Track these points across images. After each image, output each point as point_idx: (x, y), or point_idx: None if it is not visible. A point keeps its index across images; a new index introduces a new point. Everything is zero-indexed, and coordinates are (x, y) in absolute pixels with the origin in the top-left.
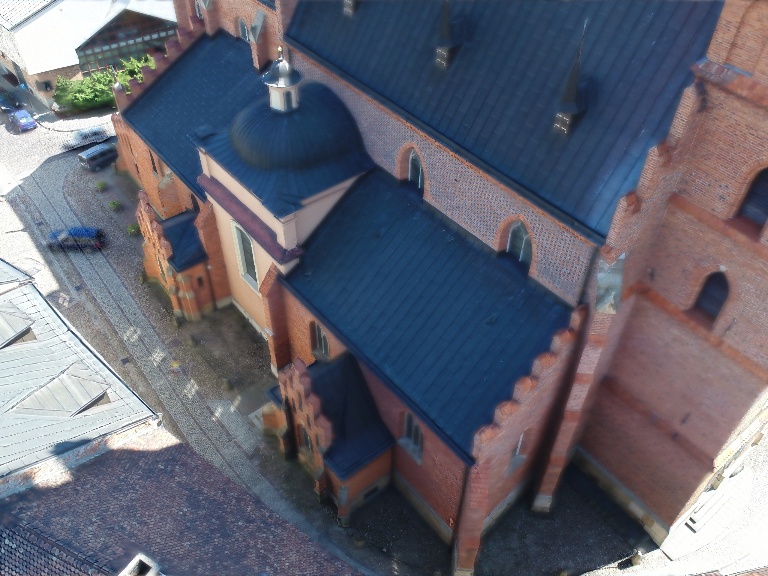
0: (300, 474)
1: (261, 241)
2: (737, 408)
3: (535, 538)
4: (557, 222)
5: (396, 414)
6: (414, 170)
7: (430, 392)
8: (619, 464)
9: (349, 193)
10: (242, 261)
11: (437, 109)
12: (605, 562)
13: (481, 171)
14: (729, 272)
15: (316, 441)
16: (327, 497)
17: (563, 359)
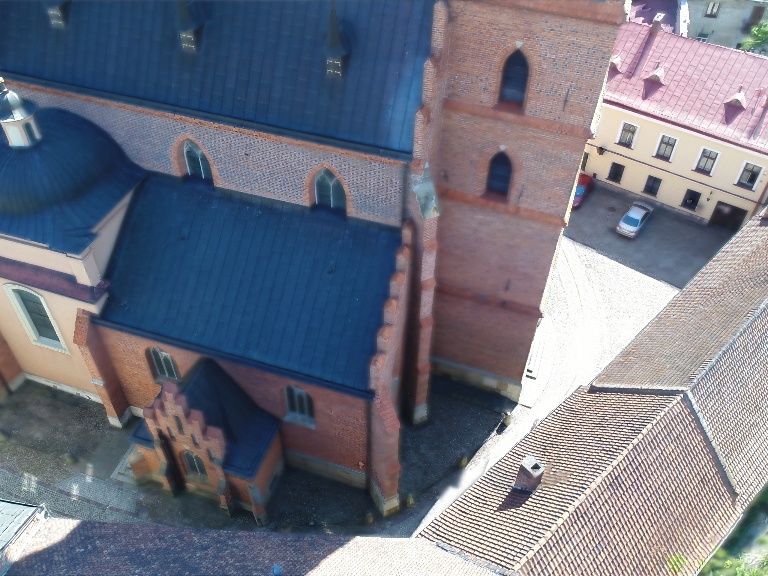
0: (196, 502)
1: (57, 290)
2: (545, 257)
3: (427, 445)
4: (363, 156)
5: (276, 393)
6: (192, 163)
7: (305, 355)
8: (464, 352)
9: (131, 209)
10: (30, 325)
11: (202, 93)
12: (487, 435)
13: (273, 136)
14: (508, 149)
15: (208, 457)
16: (235, 508)
17: (407, 274)
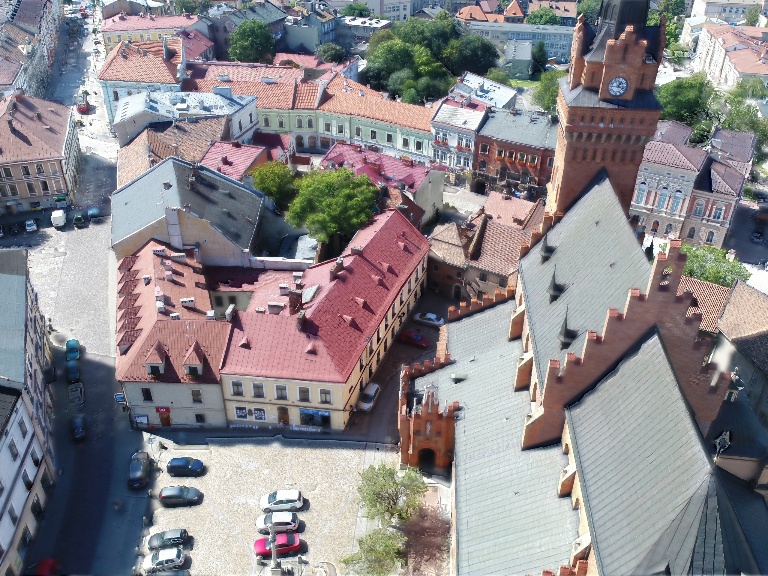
0: None
1: None
2: None
3: None
4: None
5: None
6: None
7: None
8: None
9: None
10: None
11: None
12: None
13: None
14: None
15: None
16: None
17: None
